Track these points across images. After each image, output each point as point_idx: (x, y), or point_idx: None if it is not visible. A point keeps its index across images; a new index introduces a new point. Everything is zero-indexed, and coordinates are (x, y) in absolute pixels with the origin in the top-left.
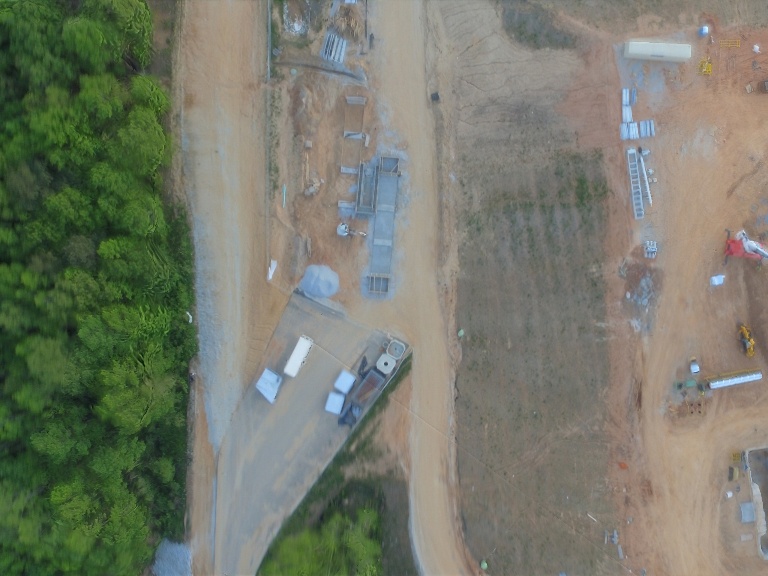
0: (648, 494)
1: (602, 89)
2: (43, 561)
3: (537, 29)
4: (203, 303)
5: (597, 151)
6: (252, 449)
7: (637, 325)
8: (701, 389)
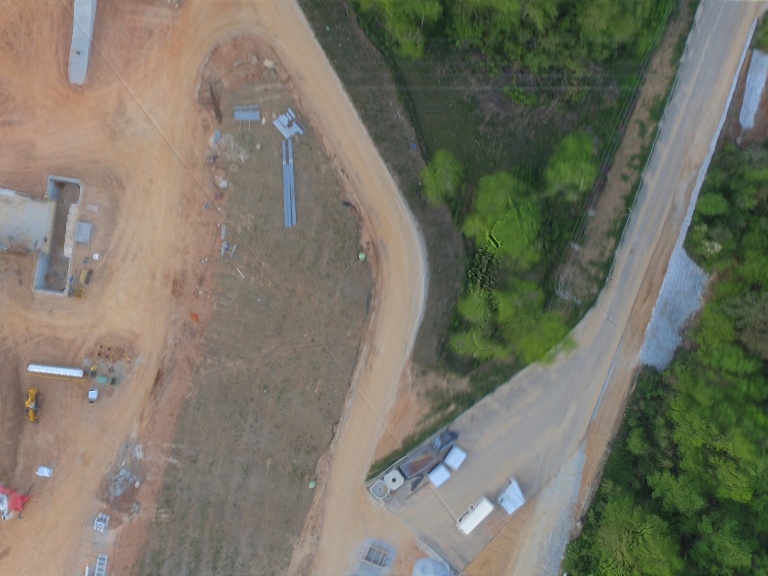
0: (179, 282)
1: None
2: None
3: None
4: None
5: None
6: (549, 437)
7: (138, 452)
8: (94, 373)
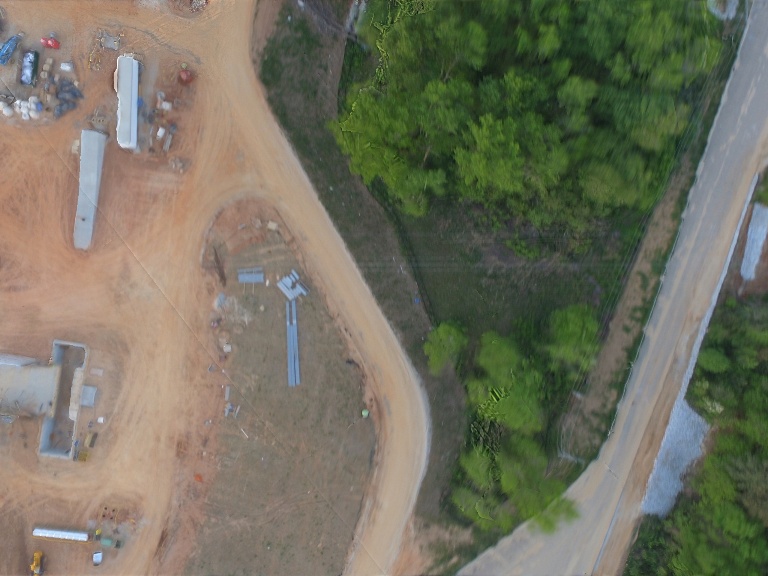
0: (183, 444)
1: None
2: None
3: None
4: None
5: None
6: None
7: None
8: (98, 537)
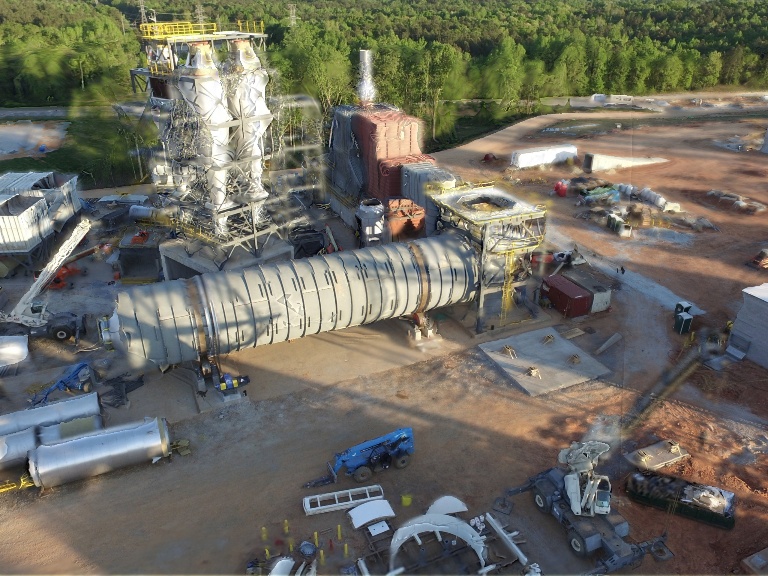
0: None
1: None
2: None
3: None
4: None
5: None
6: None
7: None
8: None
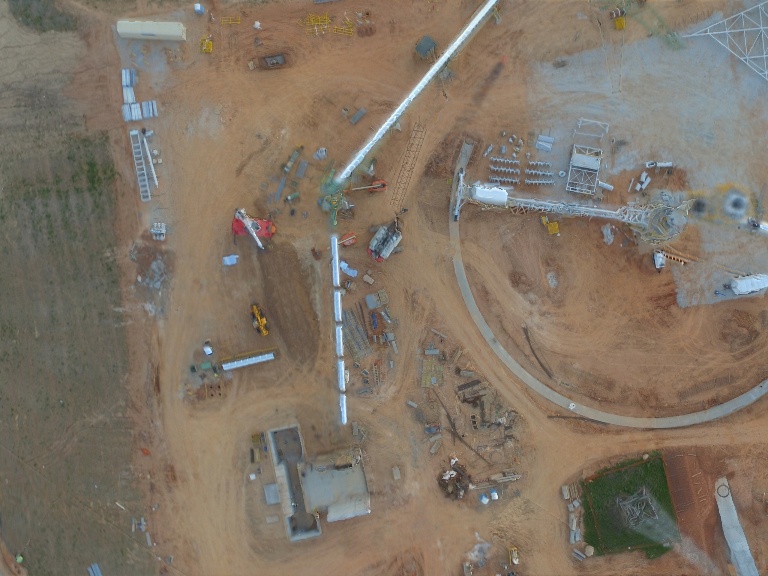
0: (172, 479)
1: (104, 70)
2: None
3: (41, 11)
4: None
5: (104, 133)
6: None
7: (151, 309)
8: (214, 371)
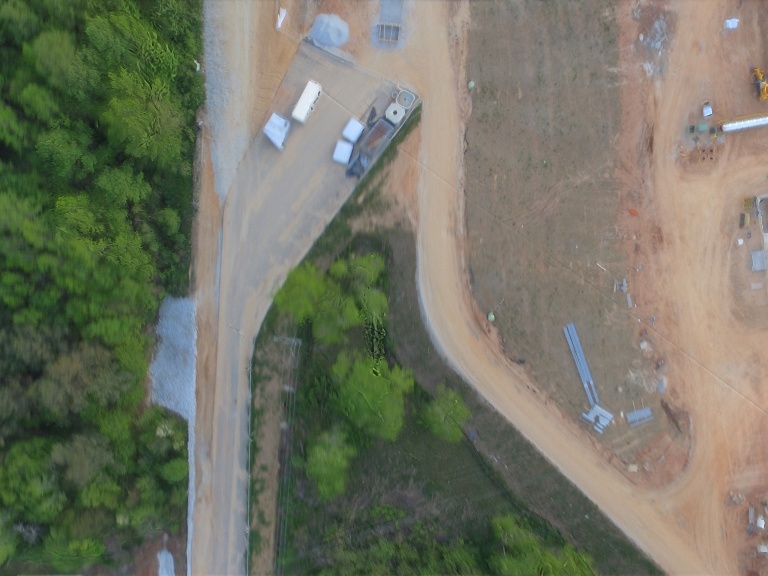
0: (658, 241)
1: None
2: (46, 281)
3: None
4: (211, 52)
5: None
6: (258, 199)
7: (650, 68)
8: (713, 132)
